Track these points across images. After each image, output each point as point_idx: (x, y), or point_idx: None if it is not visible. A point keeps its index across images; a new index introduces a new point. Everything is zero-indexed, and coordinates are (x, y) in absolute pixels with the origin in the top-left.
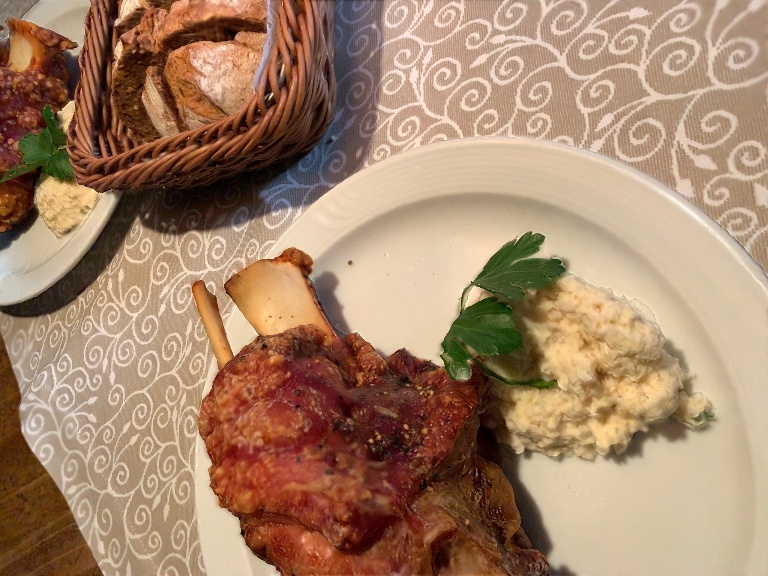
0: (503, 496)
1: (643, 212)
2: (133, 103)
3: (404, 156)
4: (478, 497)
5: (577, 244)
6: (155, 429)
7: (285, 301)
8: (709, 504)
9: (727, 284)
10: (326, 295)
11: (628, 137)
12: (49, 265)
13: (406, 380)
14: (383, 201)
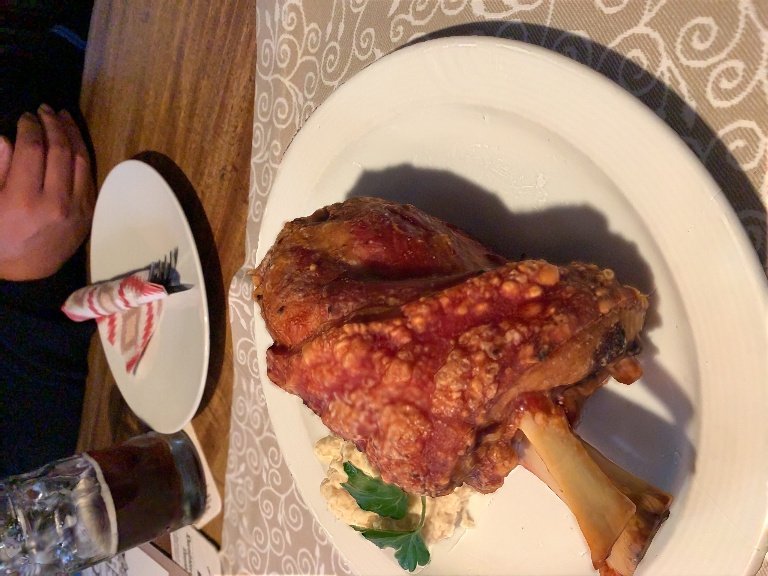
0: None
1: (376, 575)
2: None
3: None
4: None
5: None
6: None
7: None
8: None
9: (331, 524)
10: None
11: None
12: None
13: None
14: None
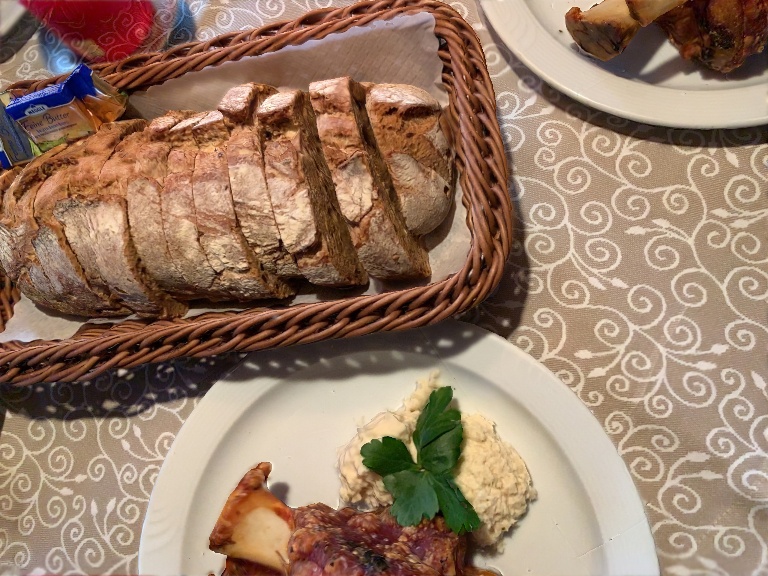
0: None
1: None
2: (402, 230)
3: None
4: None
5: None
6: (764, 254)
7: (616, 1)
8: None
9: None
10: None
11: None
12: (586, 467)
13: None
14: None
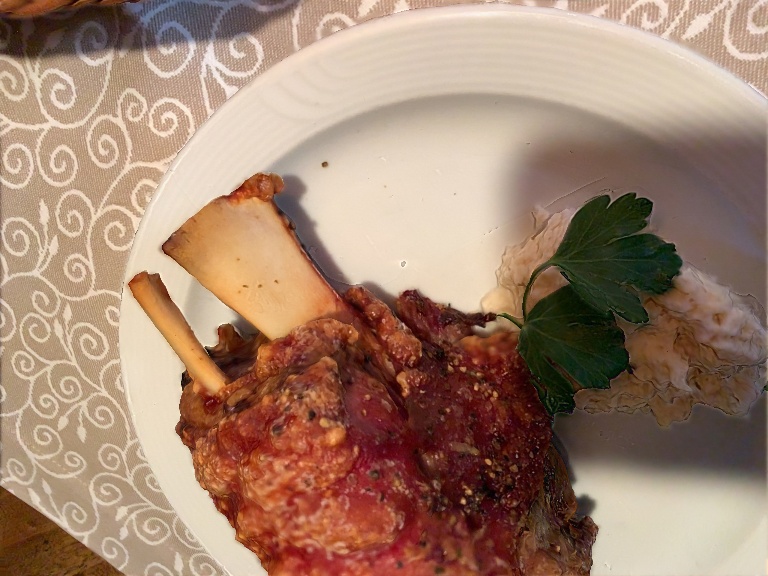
0: (563, 481)
1: None
2: None
3: (429, 20)
4: (548, 498)
5: (664, 187)
6: (29, 343)
7: (262, 260)
8: (737, 454)
9: None
10: (289, 207)
11: (746, 19)
12: None
13: (443, 357)
14: (387, 88)
